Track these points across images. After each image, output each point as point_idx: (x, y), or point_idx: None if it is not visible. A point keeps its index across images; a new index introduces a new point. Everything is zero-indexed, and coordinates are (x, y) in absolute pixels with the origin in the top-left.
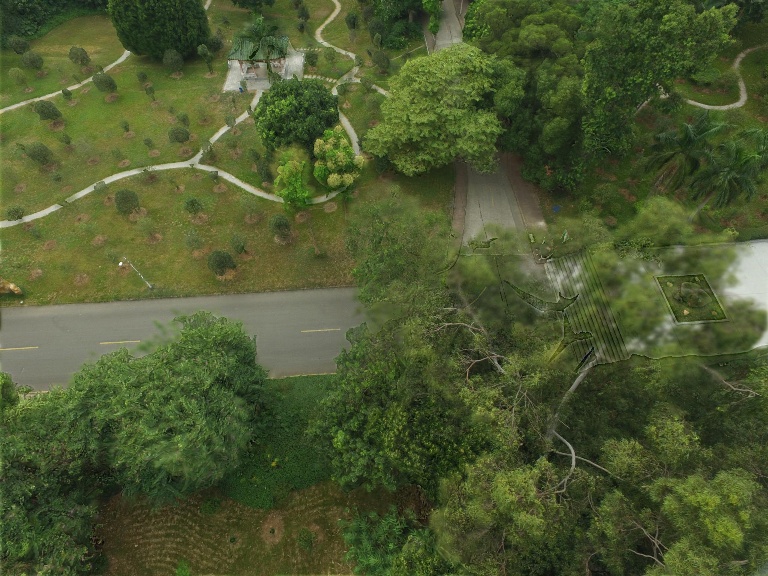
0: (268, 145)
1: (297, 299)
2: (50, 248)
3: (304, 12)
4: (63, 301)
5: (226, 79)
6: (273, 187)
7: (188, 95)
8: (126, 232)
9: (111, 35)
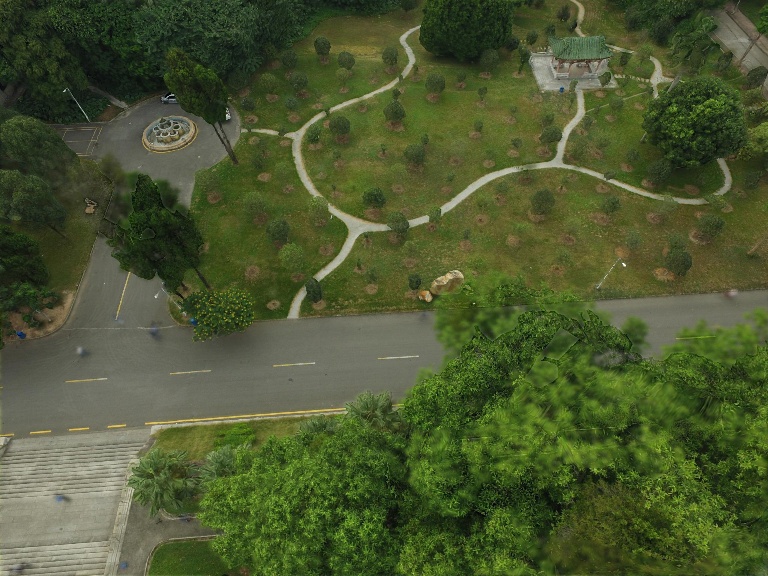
0: (684, 145)
1: (748, 300)
2: (469, 249)
3: (567, 12)
4: (514, 302)
5: (536, 79)
6: (656, 187)
7: (509, 95)
8: (535, 233)
9: (376, 35)
